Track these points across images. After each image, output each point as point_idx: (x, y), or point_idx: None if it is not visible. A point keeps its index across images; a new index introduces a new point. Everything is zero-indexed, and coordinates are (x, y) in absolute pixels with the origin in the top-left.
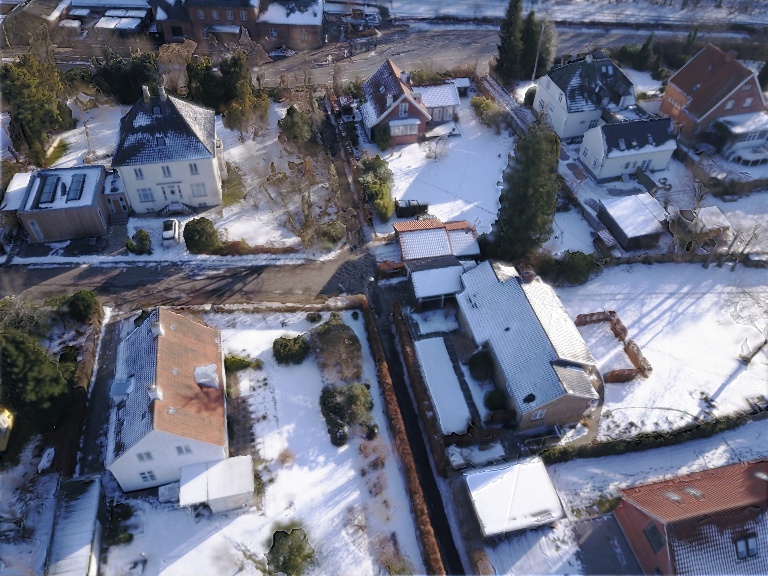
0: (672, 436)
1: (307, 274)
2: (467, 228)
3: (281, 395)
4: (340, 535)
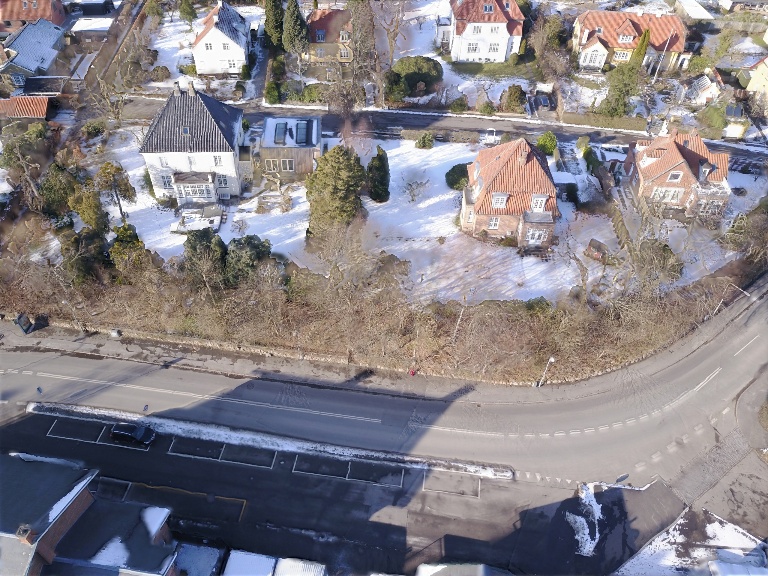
0: (1, 39)
1: (129, 113)
2: (29, 2)
3: (174, 63)
4: (169, 35)
